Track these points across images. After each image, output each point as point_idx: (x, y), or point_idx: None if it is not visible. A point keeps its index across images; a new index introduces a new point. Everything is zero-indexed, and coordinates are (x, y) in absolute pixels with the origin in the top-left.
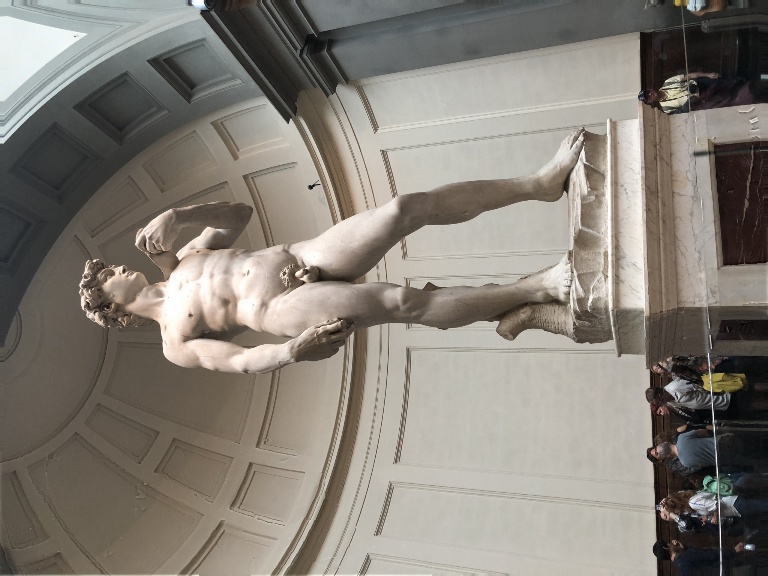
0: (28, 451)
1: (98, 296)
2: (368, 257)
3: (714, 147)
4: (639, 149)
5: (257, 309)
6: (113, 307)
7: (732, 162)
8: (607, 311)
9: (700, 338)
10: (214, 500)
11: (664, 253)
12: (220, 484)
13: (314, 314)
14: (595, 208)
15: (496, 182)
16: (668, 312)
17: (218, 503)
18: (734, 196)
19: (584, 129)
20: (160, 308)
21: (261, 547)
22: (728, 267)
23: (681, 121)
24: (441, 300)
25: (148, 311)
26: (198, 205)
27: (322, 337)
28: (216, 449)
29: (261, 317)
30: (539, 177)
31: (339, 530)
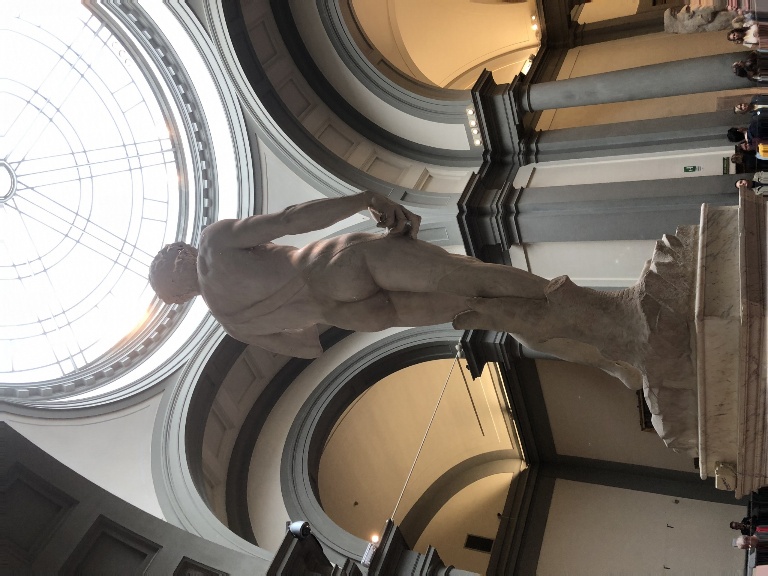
0: None
1: None
2: None
3: None
4: None
5: None
6: None
7: None
8: (696, 233)
9: None
10: None
11: None
12: None
13: None
14: None
15: None
16: (764, 201)
17: None
18: None
19: None
20: None
21: None
22: None
23: None
24: None
25: None
26: None
27: None
28: None
29: None
30: None
31: None
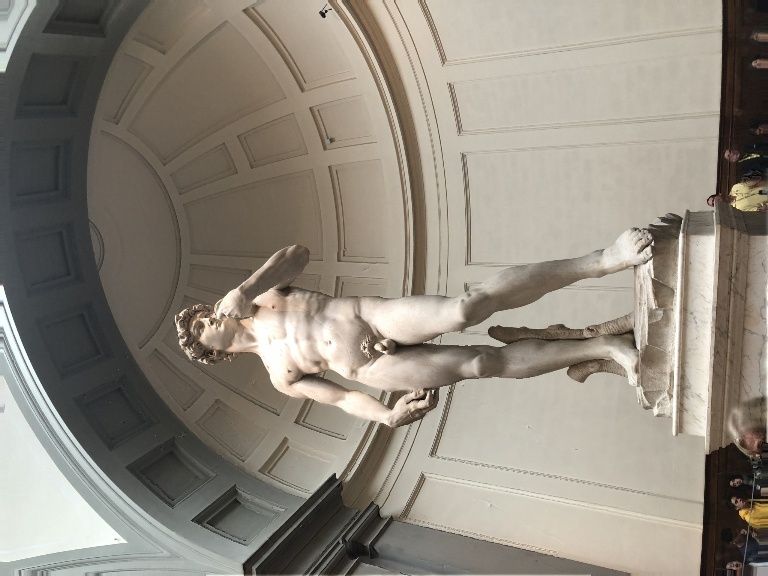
0: (157, 327)
1: (199, 348)
2: None
3: None
4: (712, 275)
5: (348, 375)
6: (216, 353)
7: None
8: None
9: None
10: None
11: (728, 394)
12: None
13: (402, 386)
14: (663, 327)
15: (559, 274)
16: None
17: None
18: None
19: (653, 239)
20: (256, 350)
21: None
22: None
23: (762, 246)
24: (514, 369)
25: (246, 350)
26: (259, 275)
27: (415, 413)
28: (304, 271)
29: (353, 379)
30: (604, 269)
31: None
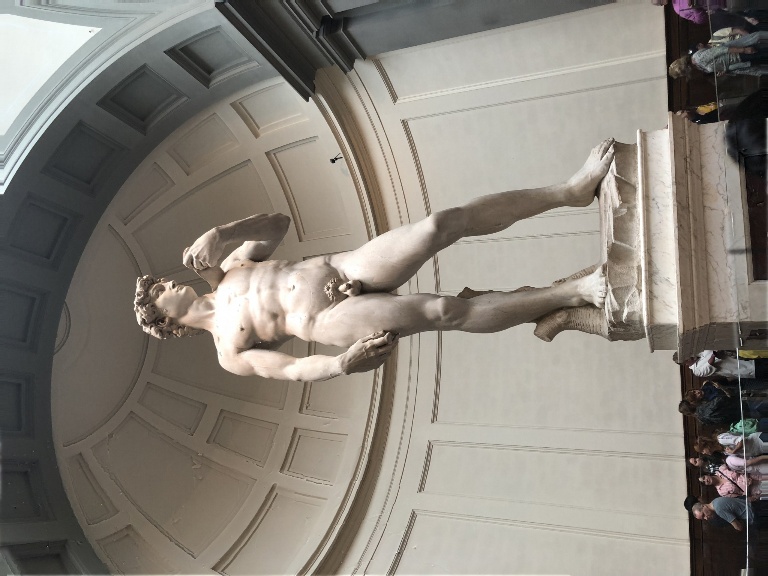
0: (90, 433)
1: (152, 312)
2: (407, 270)
3: (744, 158)
4: (669, 161)
5: (305, 323)
6: (167, 321)
7: (762, 174)
8: (641, 322)
9: (731, 340)
10: (264, 465)
11: (696, 269)
12: (268, 449)
13: (360, 328)
14: (627, 221)
15: (528, 193)
16: (701, 327)
17: (269, 468)
18: (764, 209)
19: None
20: (211, 320)
21: (313, 507)
22: (758, 282)
23: (711, 131)
24: (480, 309)
25: (200, 323)
26: (239, 221)
27: (370, 351)
28: (262, 417)
29: (309, 330)
30: (570, 187)
31: (384, 488)
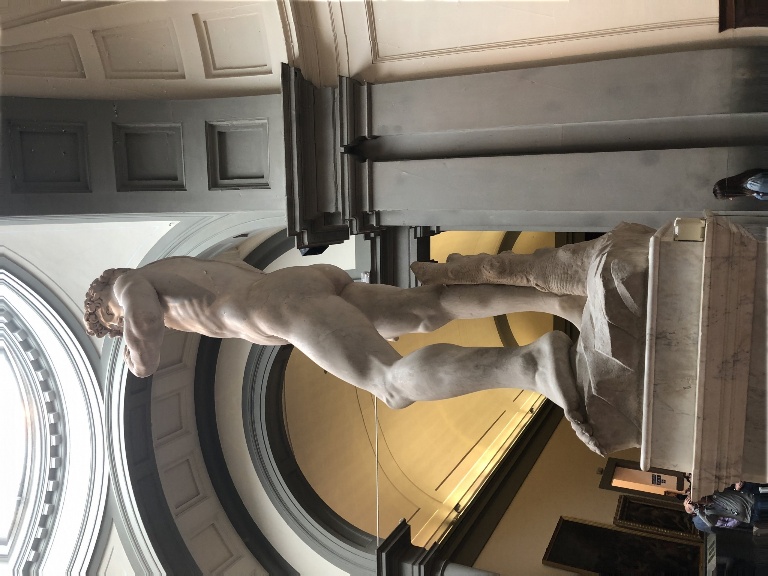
0: None
1: None
2: None
3: None
4: None
5: None
6: None
7: None
8: None
9: None
10: None
11: None
12: None
13: None
14: None
15: None
16: None
17: None
18: None
19: None
20: None
21: None
22: None
23: None
24: None
25: None
26: None
27: None
28: None
29: None
30: None
31: None
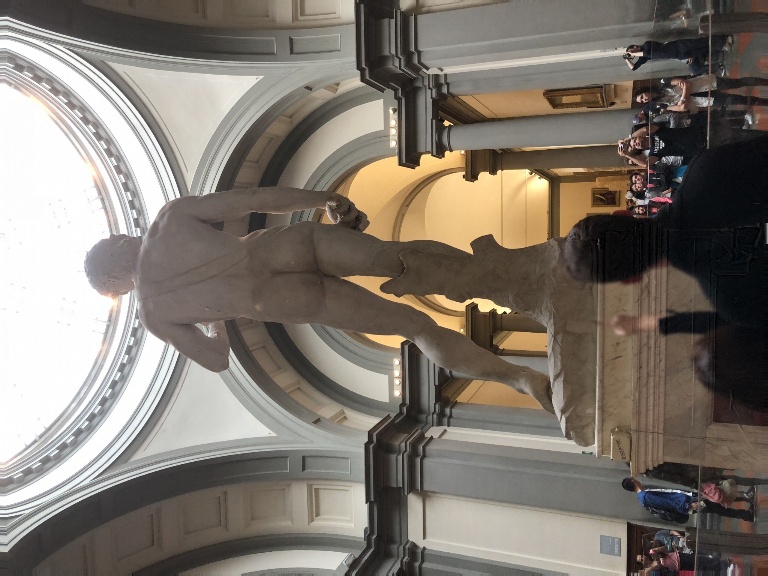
0: None
1: None
2: None
3: None
4: None
5: None
6: None
7: None
8: None
9: None
10: None
11: None
12: None
13: None
14: None
15: None
16: None
17: None
18: None
19: None
20: None
21: None
22: None
23: None
24: None
25: None
26: None
27: None
28: None
29: None
30: None
31: None
